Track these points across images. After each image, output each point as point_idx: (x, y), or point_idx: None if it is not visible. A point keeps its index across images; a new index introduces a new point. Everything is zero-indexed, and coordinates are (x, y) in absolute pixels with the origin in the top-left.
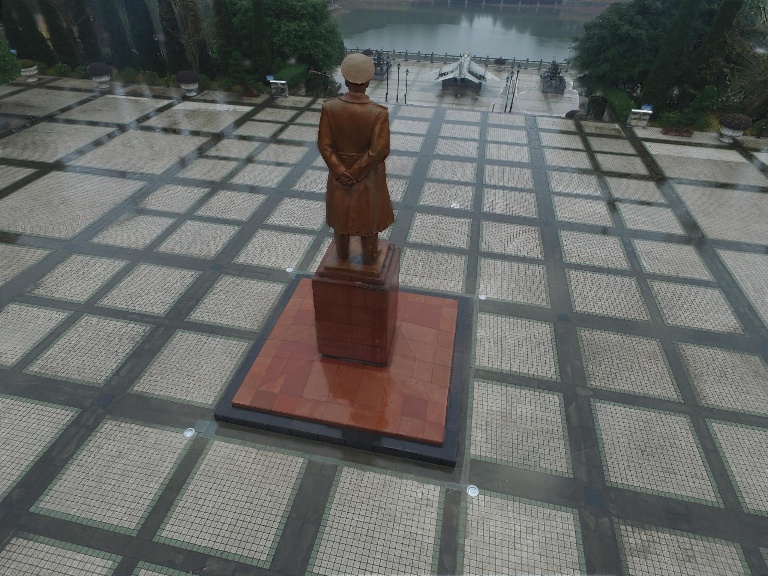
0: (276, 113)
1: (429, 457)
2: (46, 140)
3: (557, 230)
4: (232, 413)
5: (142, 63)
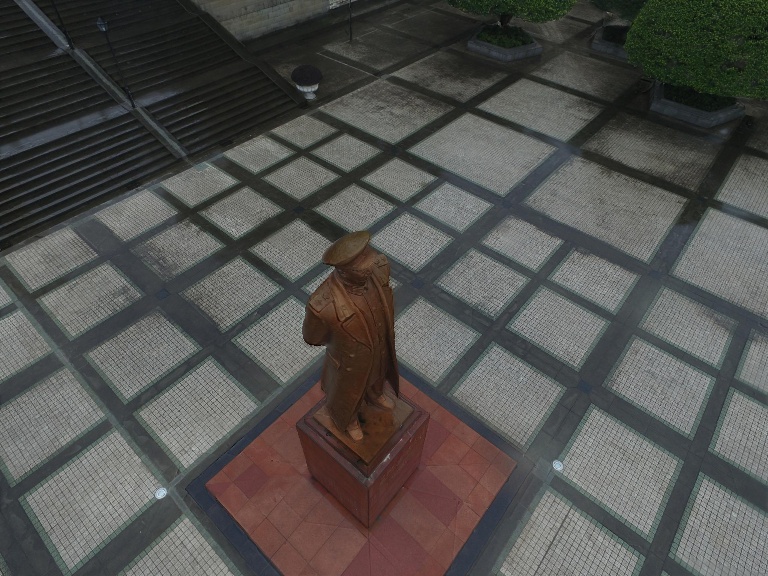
0: None
1: (207, 468)
2: None
3: None
4: None
5: None
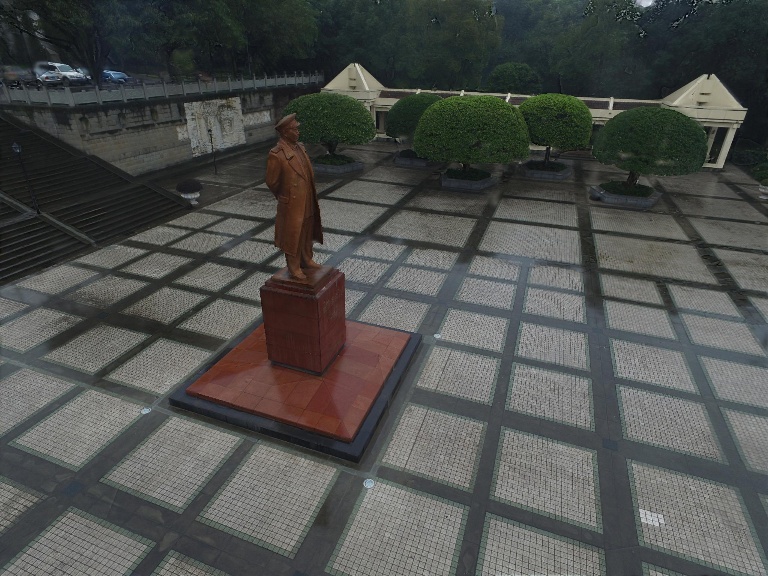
0: None
1: (183, 385)
2: (634, 221)
3: None
4: None
5: None
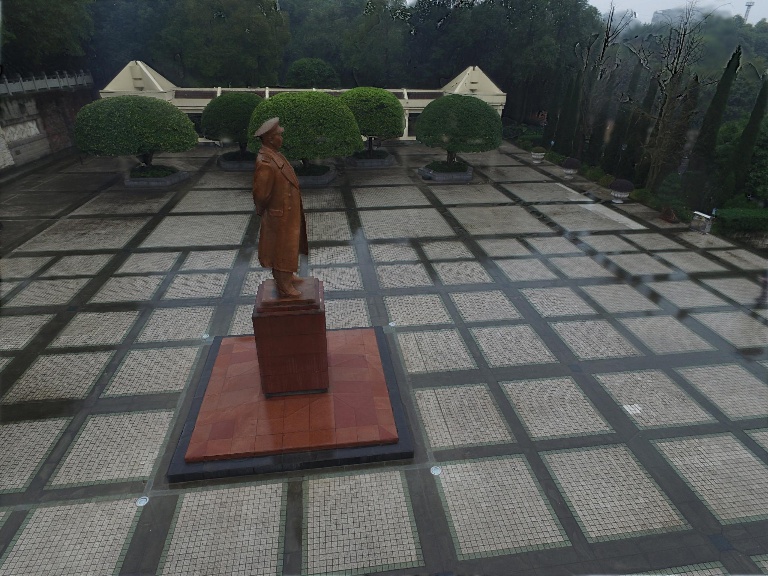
0: (656, 240)
1: None
2: (468, 193)
3: (713, 560)
4: (216, 343)
5: (618, 169)
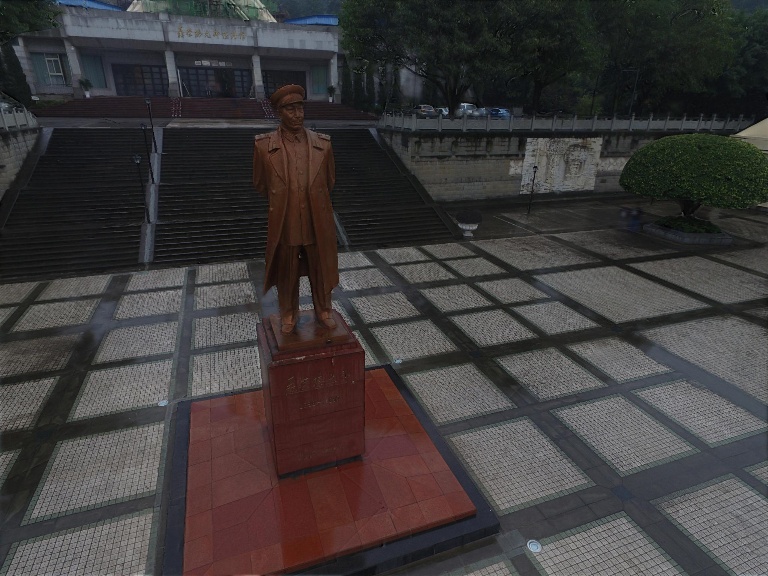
0: None
1: None
2: None
3: None
4: (378, 368)
5: None
